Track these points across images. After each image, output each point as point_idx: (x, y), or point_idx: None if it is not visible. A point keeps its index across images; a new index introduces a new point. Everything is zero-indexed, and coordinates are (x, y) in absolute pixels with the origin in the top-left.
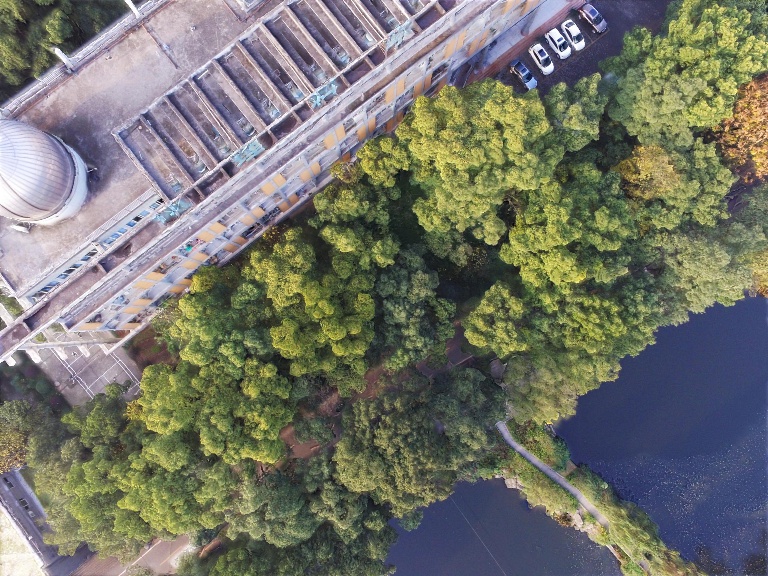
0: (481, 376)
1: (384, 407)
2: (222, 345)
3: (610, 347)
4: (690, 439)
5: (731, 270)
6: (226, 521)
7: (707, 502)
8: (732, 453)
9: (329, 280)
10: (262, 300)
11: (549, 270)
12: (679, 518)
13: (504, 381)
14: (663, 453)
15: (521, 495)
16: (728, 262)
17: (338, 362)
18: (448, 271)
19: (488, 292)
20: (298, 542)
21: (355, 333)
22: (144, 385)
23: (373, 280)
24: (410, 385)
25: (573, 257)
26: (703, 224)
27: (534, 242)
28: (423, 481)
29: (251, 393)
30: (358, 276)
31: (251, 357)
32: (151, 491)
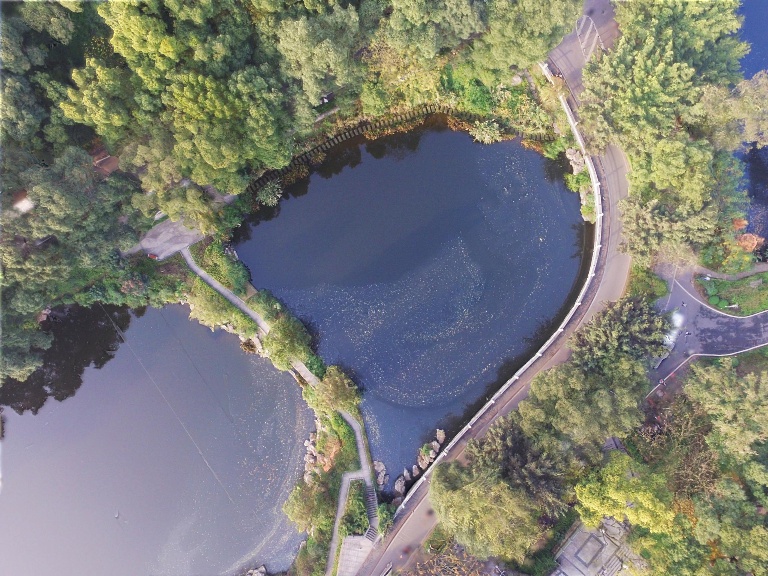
0: (86, 155)
1: None
2: None
3: (215, 129)
4: (374, 268)
5: (319, 45)
6: None
7: (387, 329)
8: (414, 282)
9: None
10: None
11: (132, 38)
12: (358, 344)
13: None
14: (346, 281)
15: None
16: (305, 31)
17: None
18: None
19: None
20: None
21: None
22: None
23: None
24: None
25: (146, 20)
26: (317, 14)
27: (112, 6)
28: None
29: None
30: None
31: None
32: None
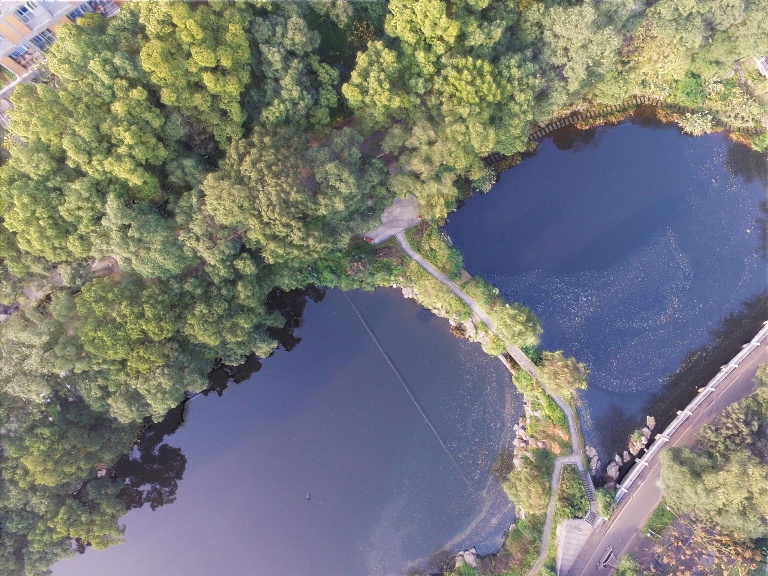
0: (359, 136)
1: (255, 145)
2: (91, 60)
3: (485, 113)
4: (584, 255)
5: (599, 32)
6: (93, 244)
7: (598, 316)
8: (624, 270)
9: (201, 9)
10: (138, 33)
11: (421, 22)
12: (570, 330)
13: (384, 148)
14: (557, 268)
15: (418, 306)
16: (593, 17)
17: (214, 105)
18: (340, 54)
19: (366, 51)
20: (167, 276)
21: (225, 63)
22: (14, 97)
23: (247, 18)
24: (283, 129)
25: (442, 4)
26: (581, 2)
27: None
28: (289, 215)
29: (117, 107)
30: (231, 9)
31: (121, 78)
32: (13, 194)
